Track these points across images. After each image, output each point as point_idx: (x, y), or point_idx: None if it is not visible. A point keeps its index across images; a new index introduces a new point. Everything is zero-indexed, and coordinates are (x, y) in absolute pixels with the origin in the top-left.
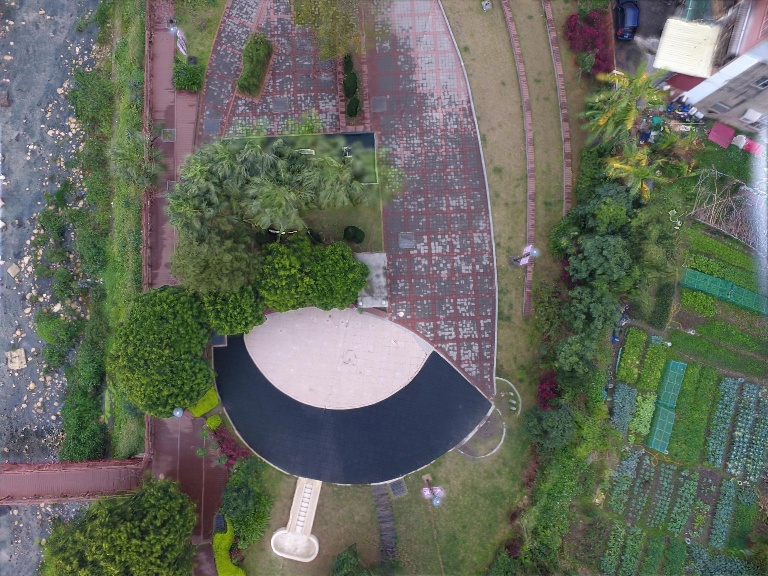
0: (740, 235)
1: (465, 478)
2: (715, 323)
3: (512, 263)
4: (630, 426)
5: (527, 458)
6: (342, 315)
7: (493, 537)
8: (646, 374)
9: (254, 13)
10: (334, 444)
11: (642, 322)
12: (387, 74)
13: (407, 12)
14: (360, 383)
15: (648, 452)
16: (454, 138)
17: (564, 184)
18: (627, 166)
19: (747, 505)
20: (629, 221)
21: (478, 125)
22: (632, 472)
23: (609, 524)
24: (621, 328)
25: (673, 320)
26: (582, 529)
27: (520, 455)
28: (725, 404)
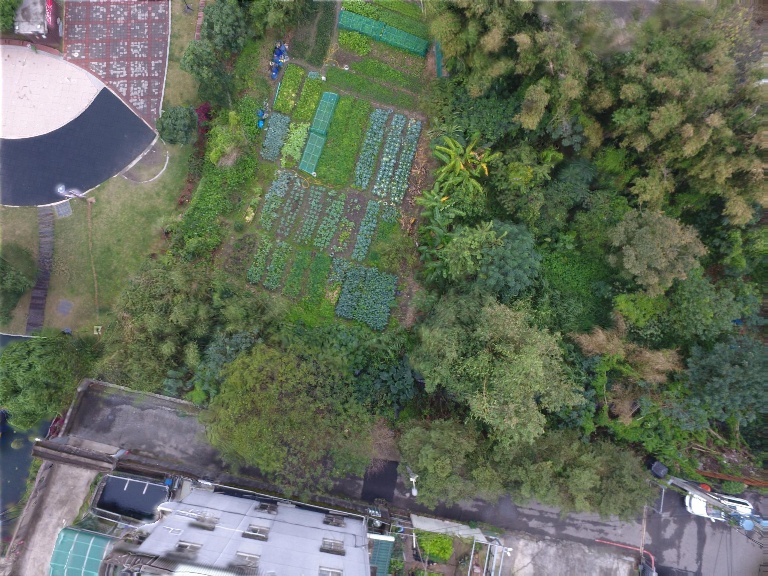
0: None
1: (125, 199)
2: (369, 60)
3: (186, 11)
4: (282, 151)
5: (185, 181)
6: (20, 55)
7: (146, 249)
8: (300, 105)
9: None
10: (4, 169)
11: (302, 61)
12: None
13: None
14: (33, 116)
15: (300, 176)
16: None
17: None
18: None
19: (389, 222)
20: None
21: None
22: (280, 191)
23: (259, 240)
24: (279, 64)
25: (330, 58)
26: (233, 244)
27: (179, 179)
28: (374, 132)
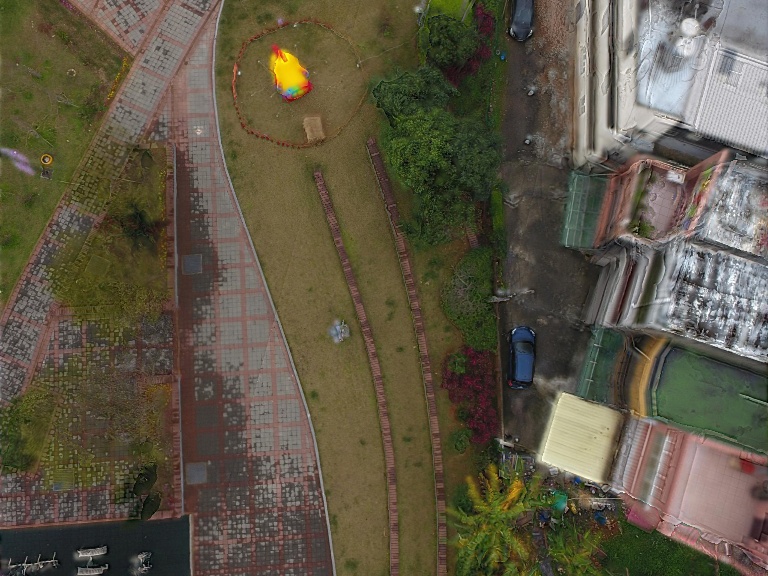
0: None
1: None
2: None
3: None
4: None
5: None
6: None
7: None
8: None
9: (32, 346)
10: None
11: None
12: (208, 430)
13: (237, 341)
14: None
15: None
16: (295, 520)
17: None
18: None
19: None
20: None
21: (327, 502)
22: None
23: None
24: None
25: None
26: None
27: None
28: None
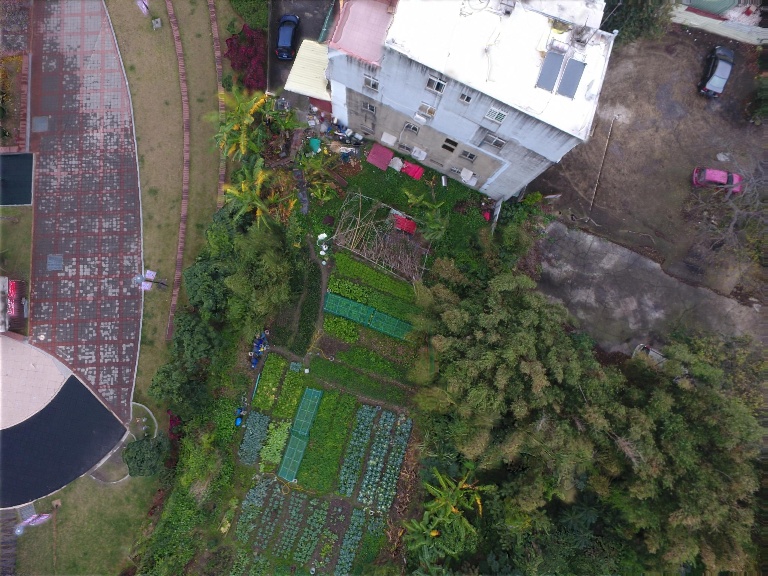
0: (381, 260)
1: (93, 504)
2: (356, 349)
3: (160, 286)
4: (260, 454)
5: None
6: None
7: (113, 564)
8: (281, 401)
9: None
10: None
11: (283, 348)
12: (51, 94)
13: (77, 31)
14: None
15: (280, 480)
16: (113, 159)
17: (216, 206)
18: (235, 191)
19: (375, 535)
20: (232, 248)
21: (137, 146)
22: (258, 500)
23: (235, 553)
24: (258, 354)
25: (314, 346)
26: (206, 557)
27: (150, 481)
28: (360, 432)
